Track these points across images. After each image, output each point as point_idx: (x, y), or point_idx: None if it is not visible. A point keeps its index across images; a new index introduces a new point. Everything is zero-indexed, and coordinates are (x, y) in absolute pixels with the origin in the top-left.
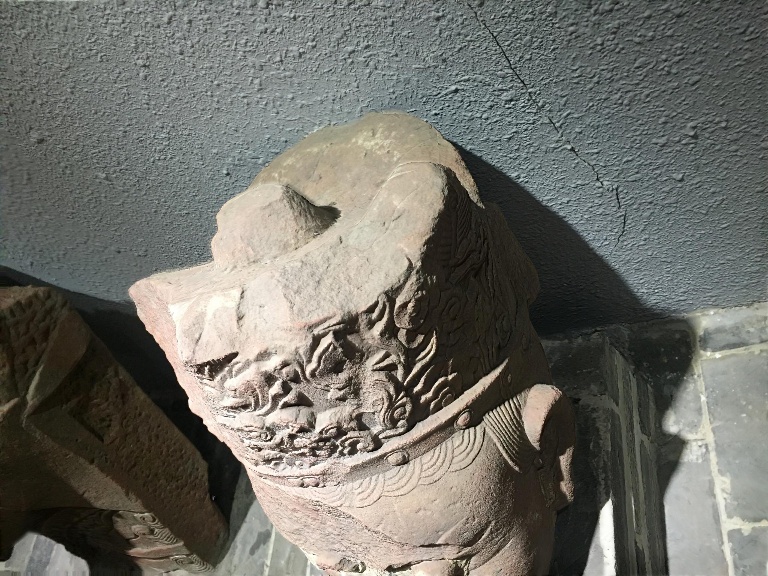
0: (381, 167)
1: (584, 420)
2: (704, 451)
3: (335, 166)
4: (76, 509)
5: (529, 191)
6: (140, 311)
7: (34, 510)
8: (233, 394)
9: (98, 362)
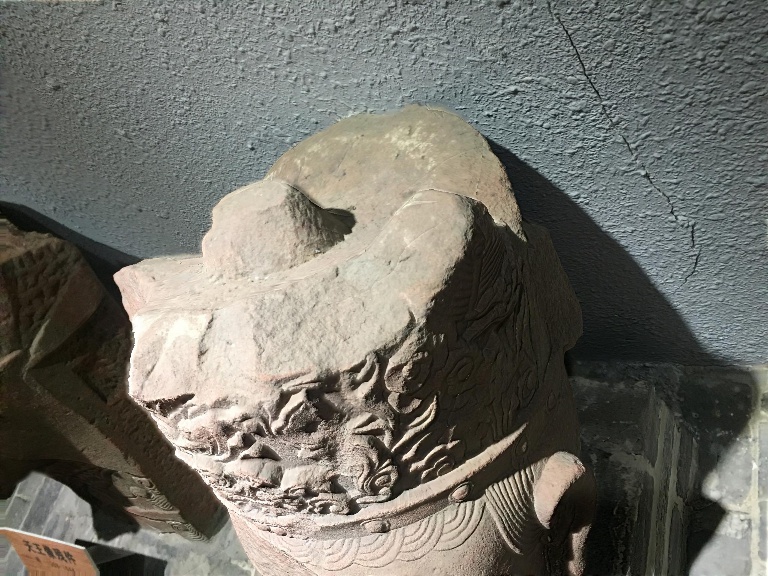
0: (412, 174)
1: (612, 479)
2: (746, 527)
3: (362, 163)
4: (76, 462)
5: (588, 213)
6: (125, 299)
7: (32, 459)
8: (187, 436)
9: (109, 321)
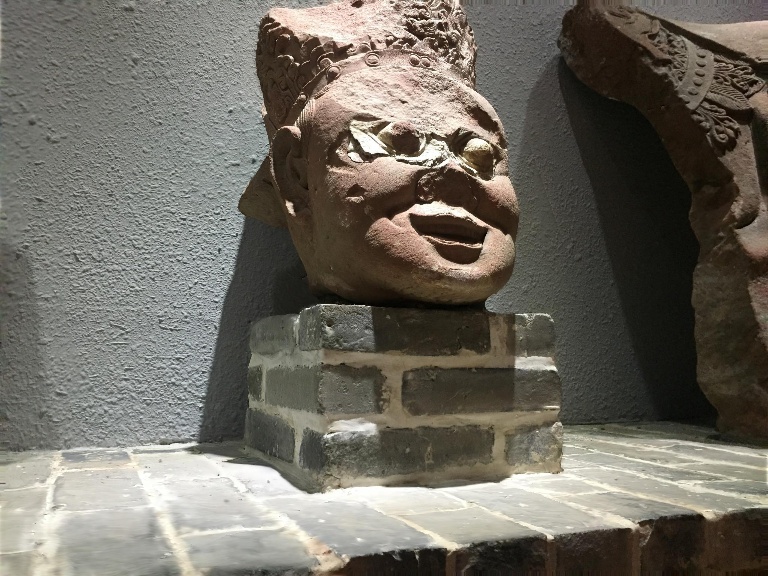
0: None
1: None
2: None
3: None
4: None
5: None
6: (275, 16)
7: None
8: None
9: None
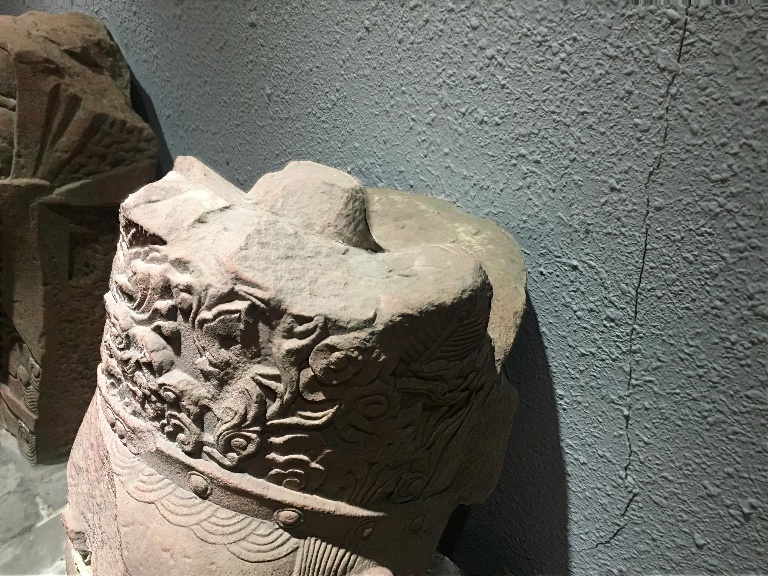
0: None
1: None
2: None
3: (423, 230)
4: (1, 309)
5: (560, 420)
6: None
7: None
8: (130, 276)
9: None
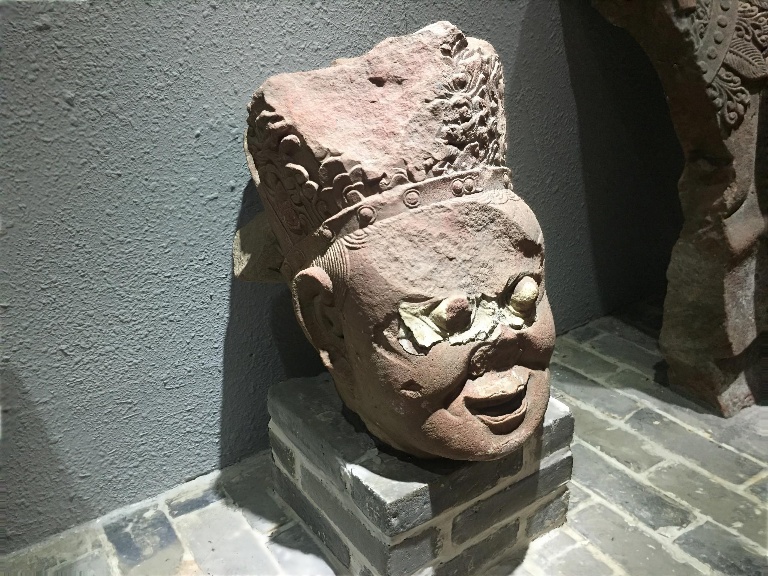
0: None
1: None
2: None
3: None
4: None
5: None
6: (272, 99)
7: None
8: (464, 69)
9: None
